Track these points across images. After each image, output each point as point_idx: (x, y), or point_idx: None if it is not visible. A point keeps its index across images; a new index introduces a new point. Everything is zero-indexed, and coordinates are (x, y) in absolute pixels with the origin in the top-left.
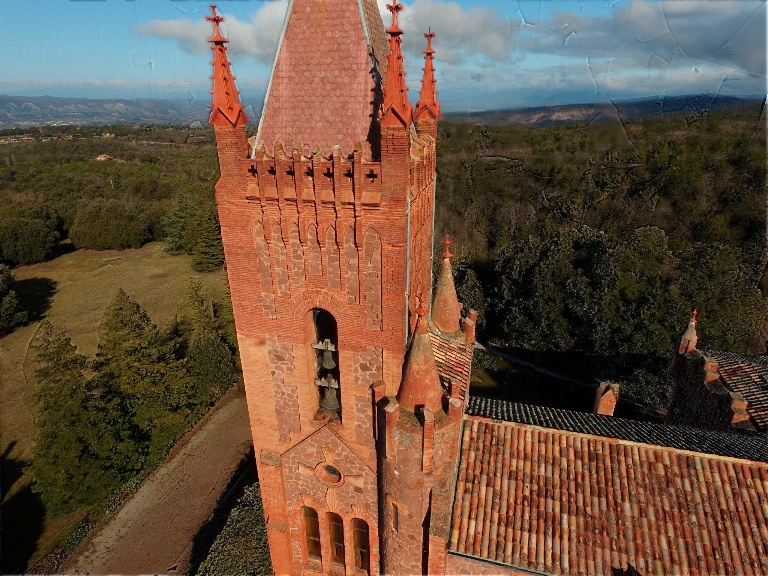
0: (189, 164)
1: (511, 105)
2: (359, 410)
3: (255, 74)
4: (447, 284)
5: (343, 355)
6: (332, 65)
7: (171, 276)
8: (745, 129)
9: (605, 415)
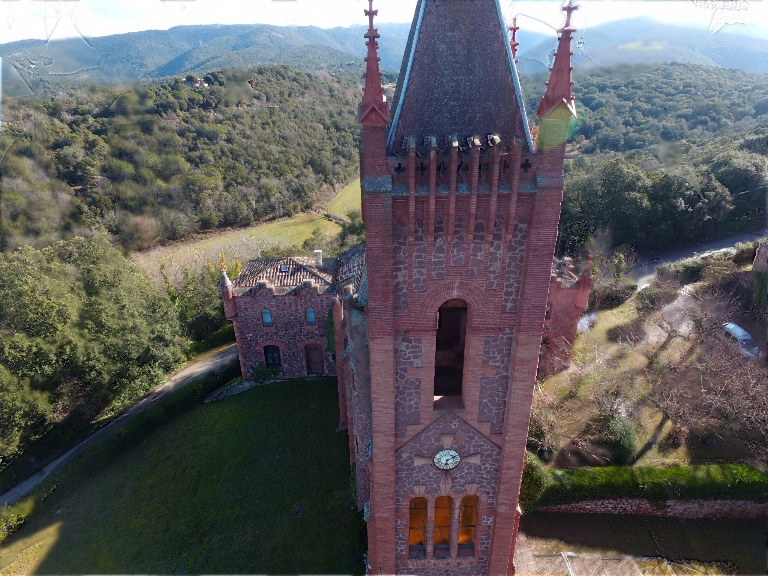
0: None
1: None
2: None
3: None
4: None
5: None
6: None
7: None
8: None
9: (344, 318)
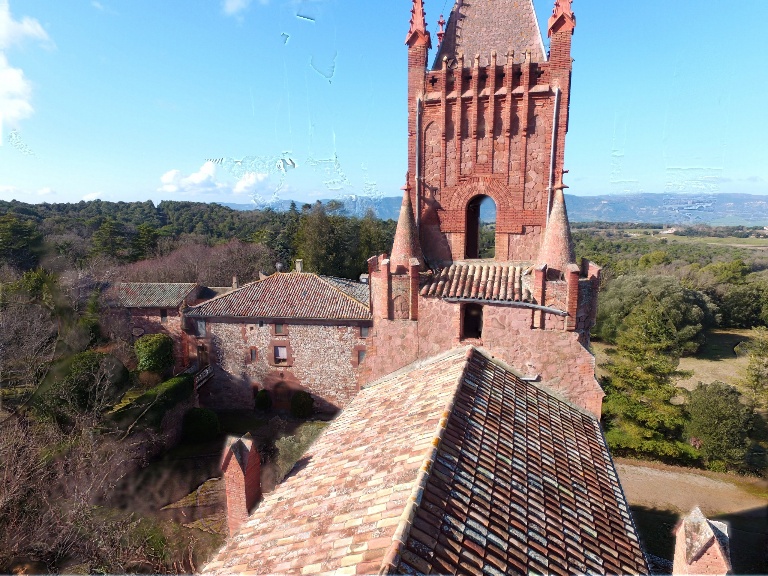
0: None
1: None
2: None
3: None
4: (549, 220)
5: None
6: None
7: None
8: None
9: None
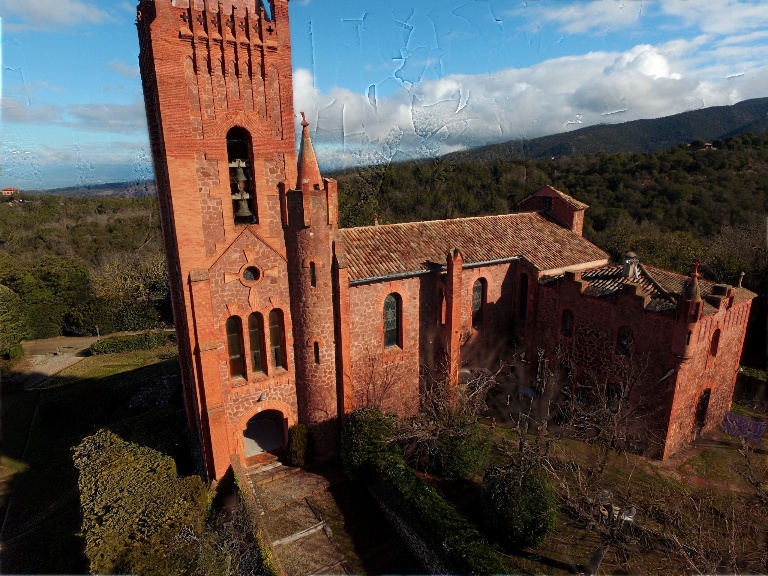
0: None
1: None
2: (270, 208)
3: None
4: None
5: (257, 163)
6: None
7: None
8: (338, 152)
9: None
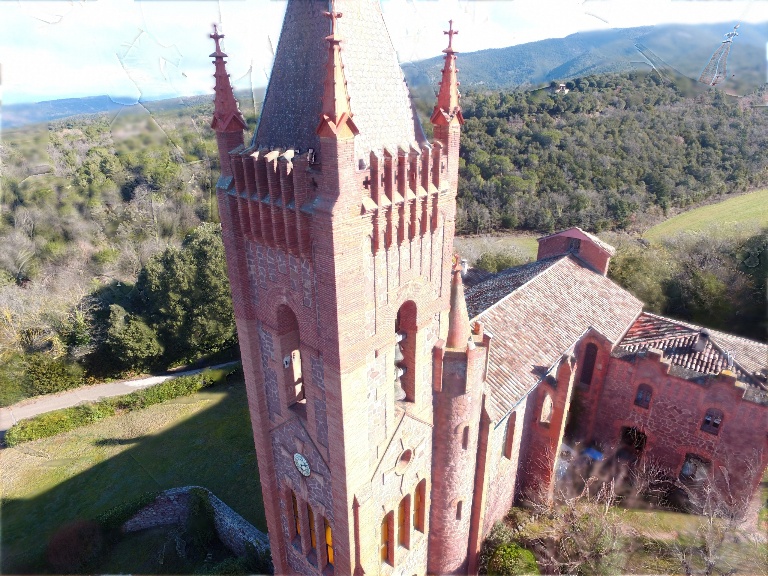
0: None
1: (20, 109)
2: (425, 378)
3: None
4: None
5: (419, 335)
6: (379, 73)
7: None
8: None
9: None
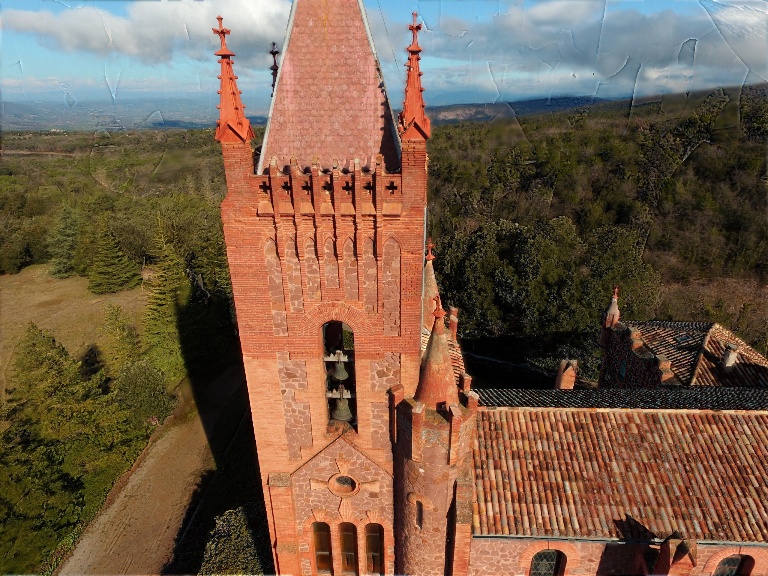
0: (95, 177)
1: None
2: (375, 416)
3: (150, 76)
4: (431, 285)
5: (360, 364)
6: (339, 79)
7: (64, 302)
8: (618, 127)
9: (567, 389)
